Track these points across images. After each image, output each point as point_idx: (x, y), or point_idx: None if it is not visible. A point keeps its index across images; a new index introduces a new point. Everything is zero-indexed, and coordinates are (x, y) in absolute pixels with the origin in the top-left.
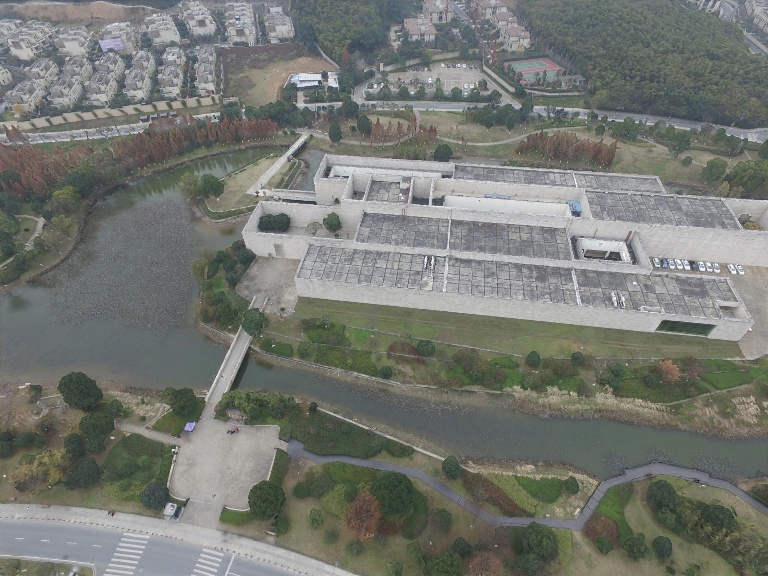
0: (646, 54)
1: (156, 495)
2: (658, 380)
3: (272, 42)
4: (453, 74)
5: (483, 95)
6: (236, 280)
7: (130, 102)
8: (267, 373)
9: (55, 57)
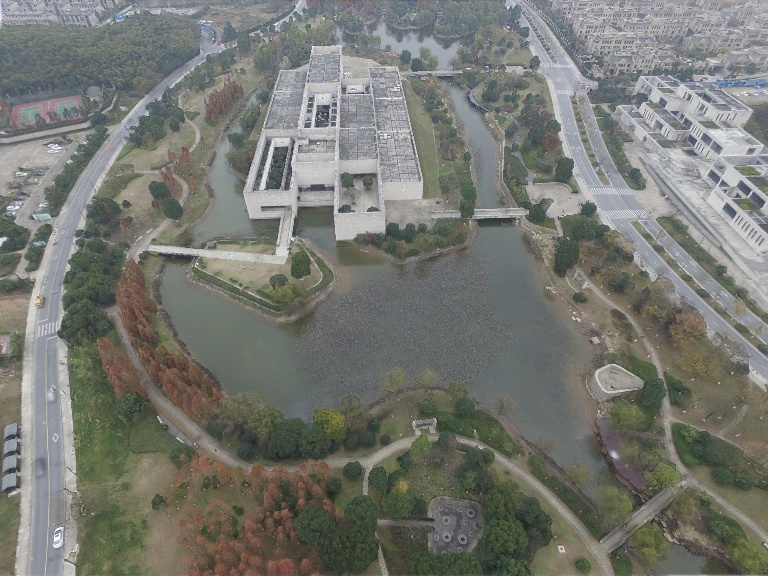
0: (93, 50)
1: None
2: (433, 93)
3: None
4: (8, 161)
5: None
6: None
7: None
8: (488, 204)
9: None
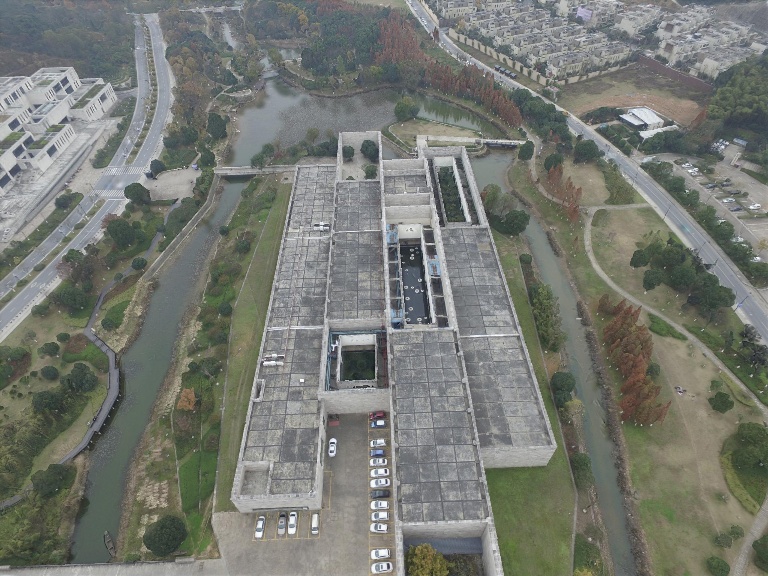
0: None
1: (153, 164)
2: None
3: (691, 72)
4: None
5: (758, 262)
6: (313, 154)
7: (508, 53)
8: (237, 188)
9: (549, 8)
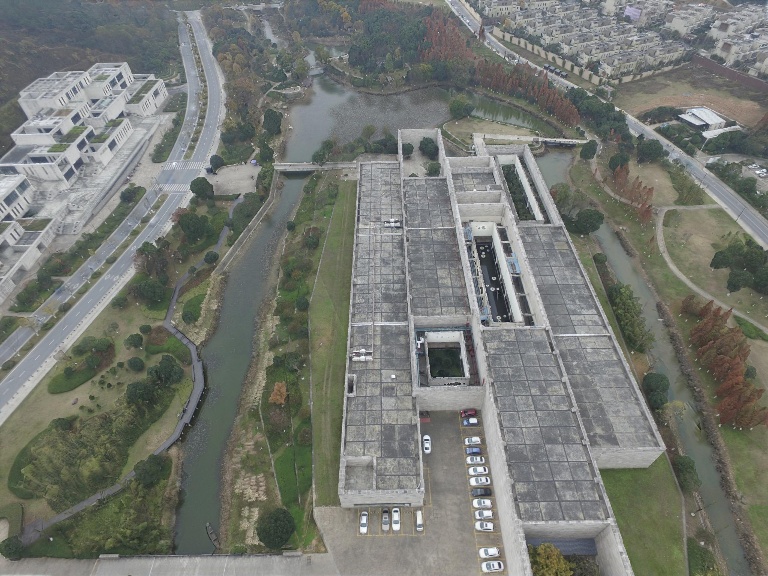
0: None
1: (213, 159)
2: None
3: (750, 72)
4: None
5: None
6: (370, 151)
7: (557, 52)
8: (297, 184)
9: (594, 7)
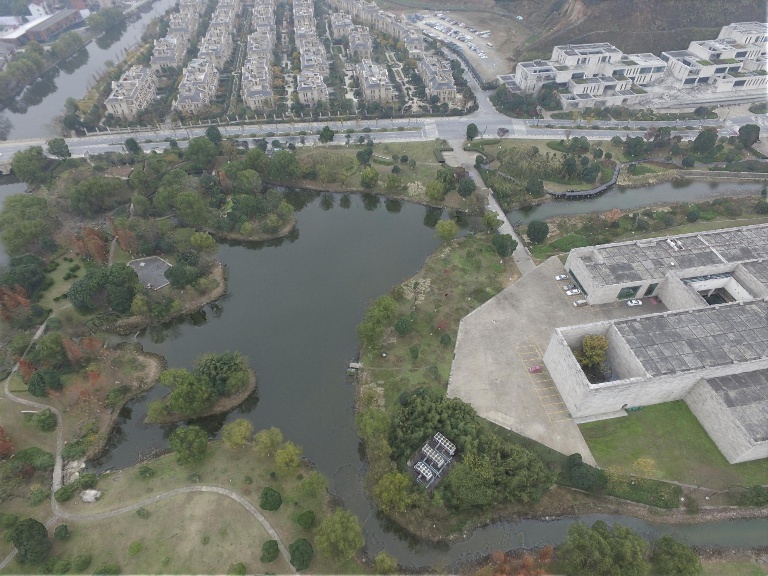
0: None
1: None
2: None
3: None
4: None
5: None
6: None
7: None
8: None
9: None
